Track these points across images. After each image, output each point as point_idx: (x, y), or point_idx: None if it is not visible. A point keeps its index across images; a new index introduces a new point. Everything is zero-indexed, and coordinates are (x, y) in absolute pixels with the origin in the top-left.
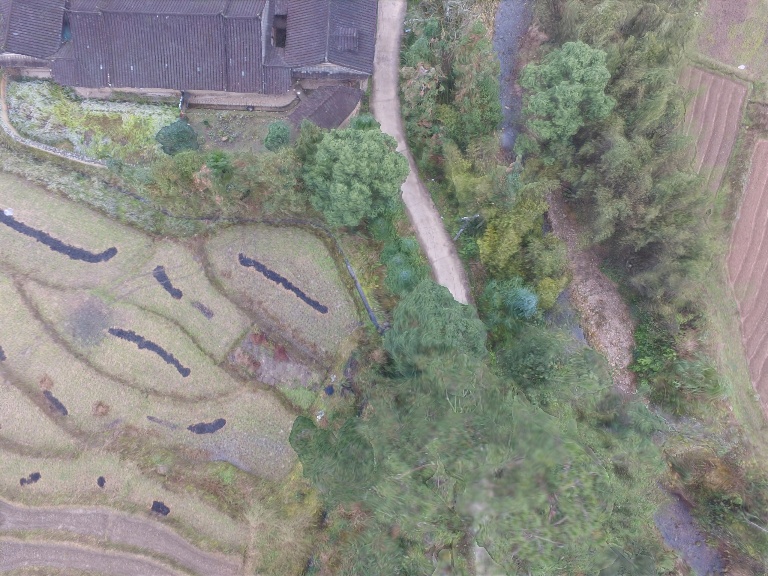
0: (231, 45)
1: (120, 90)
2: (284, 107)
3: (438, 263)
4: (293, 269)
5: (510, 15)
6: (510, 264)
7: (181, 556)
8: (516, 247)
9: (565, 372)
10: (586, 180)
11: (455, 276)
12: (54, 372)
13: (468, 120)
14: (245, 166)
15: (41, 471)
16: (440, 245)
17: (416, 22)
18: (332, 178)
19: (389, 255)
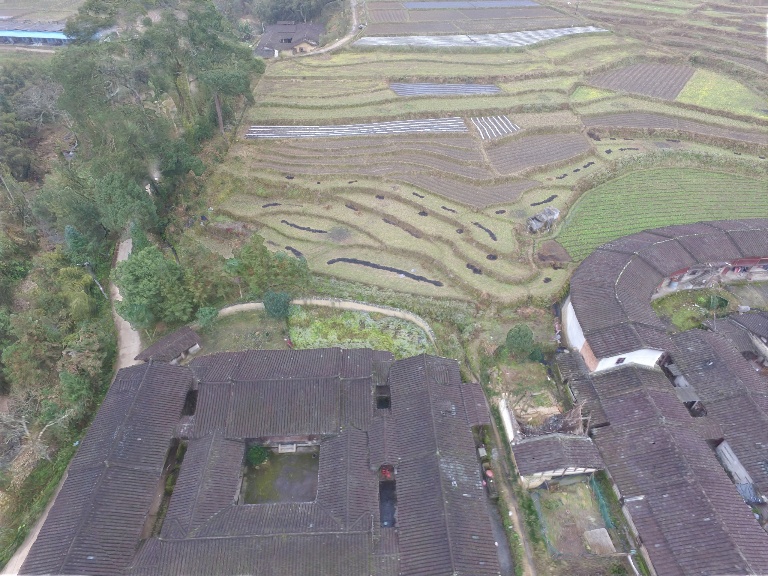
0: None
1: None
2: None
3: None
4: None
5: None
6: None
7: None
8: None
9: None
10: None
11: None
12: (355, 217)
13: (56, 332)
14: None
15: (348, 184)
16: (120, 297)
17: None
18: None
19: None
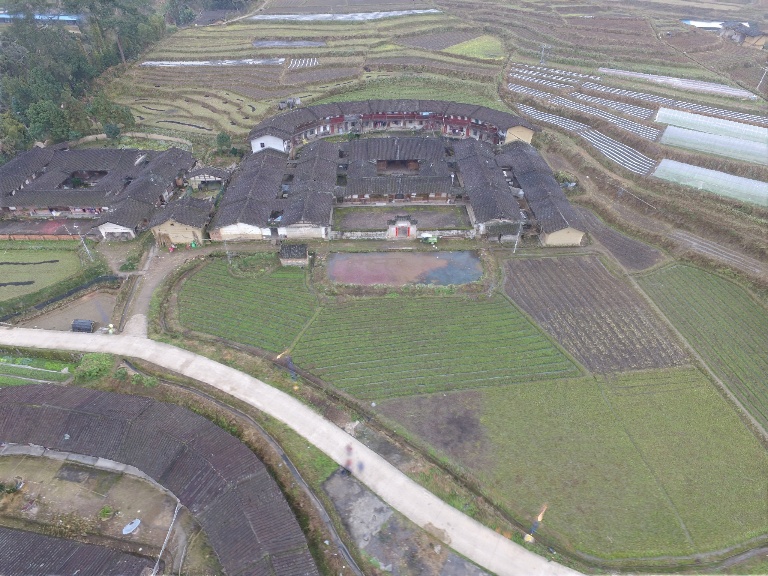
0: None
1: None
2: None
3: None
4: None
5: None
6: None
7: None
8: None
9: None
10: None
11: None
12: None
13: None
14: None
15: None
16: None
17: None
18: None
19: None
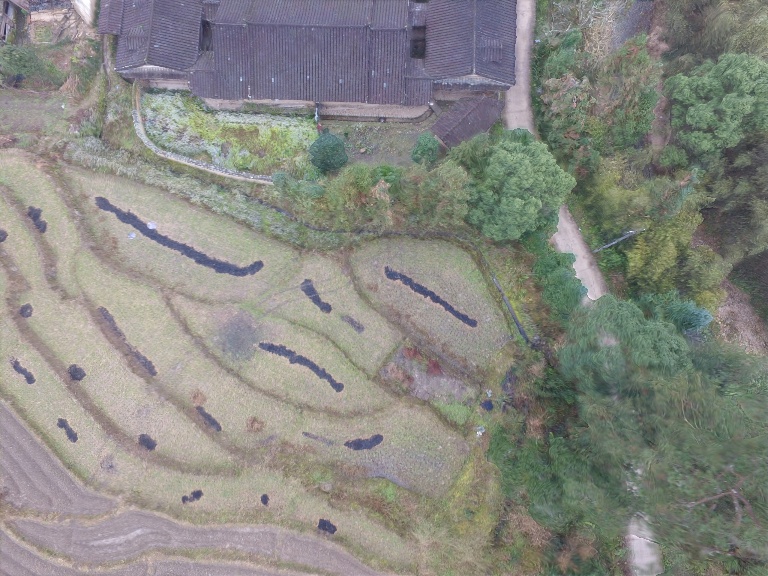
0: (375, 57)
1: (252, 102)
2: (416, 118)
3: (578, 275)
4: (440, 282)
5: (626, 24)
6: (663, 277)
7: (353, 575)
8: (674, 260)
9: (763, 390)
10: (739, 192)
11: (596, 288)
12: (206, 387)
13: (619, 132)
14: (422, 181)
15: (203, 489)
16: (579, 257)
17: (555, 33)
18: (501, 192)
19: (548, 269)
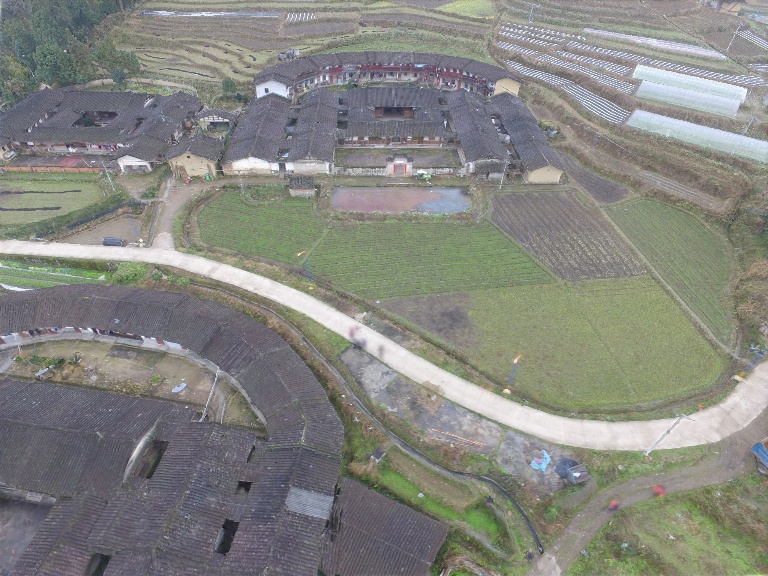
0: None
1: None
2: None
3: None
4: None
5: None
6: None
7: None
8: None
9: None
10: None
11: None
12: None
13: None
14: None
15: (190, 39)
16: None
17: (1, 106)
18: None
19: None
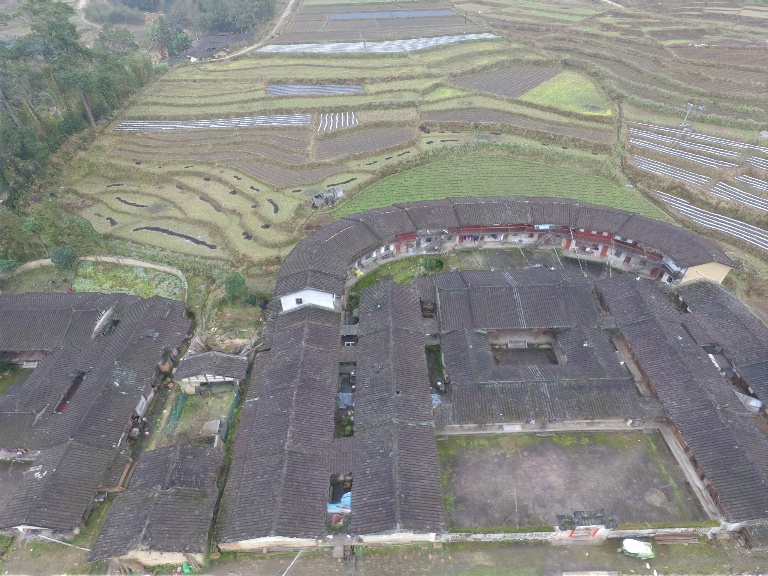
0: None
1: None
2: None
3: None
4: None
5: None
6: None
7: None
8: None
9: None
10: None
11: None
12: None
13: None
14: None
15: (184, 168)
16: None
17: None
18: None
19: None
